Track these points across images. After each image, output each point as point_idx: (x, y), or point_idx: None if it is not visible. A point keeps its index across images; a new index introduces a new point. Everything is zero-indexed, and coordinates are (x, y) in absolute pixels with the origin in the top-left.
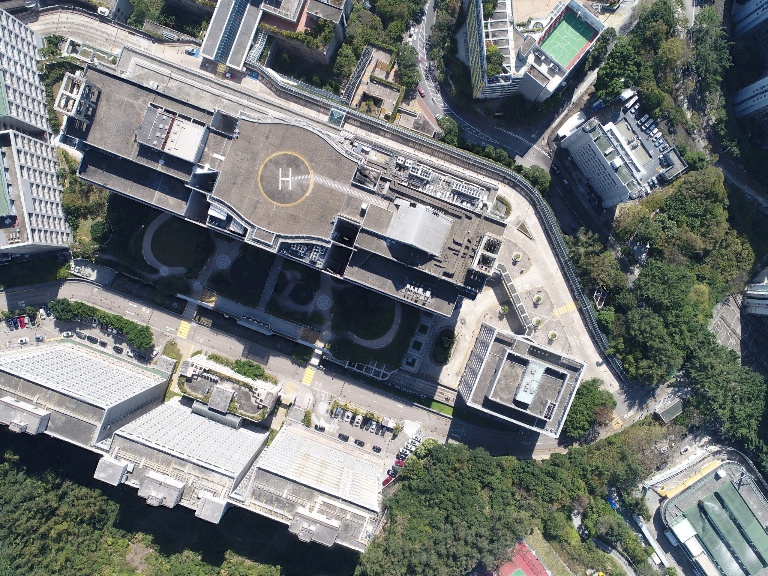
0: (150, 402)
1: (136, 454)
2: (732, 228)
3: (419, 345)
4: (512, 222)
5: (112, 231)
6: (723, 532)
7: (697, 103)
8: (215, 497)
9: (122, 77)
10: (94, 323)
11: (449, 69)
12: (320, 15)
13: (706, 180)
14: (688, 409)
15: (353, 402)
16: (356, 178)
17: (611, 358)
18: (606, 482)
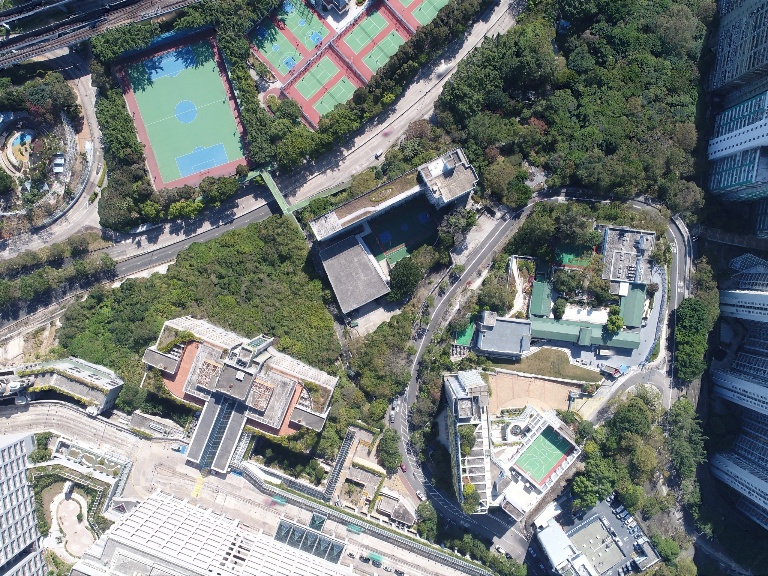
0: None
1: None
2: None
3: None
4: None
5: None
6: None
7: (673, 478)
8: None
9: None
10: None
11: (430, 445)
12: (303, 423)
13: None
14: None
15: None
16: None
17: None
18: None
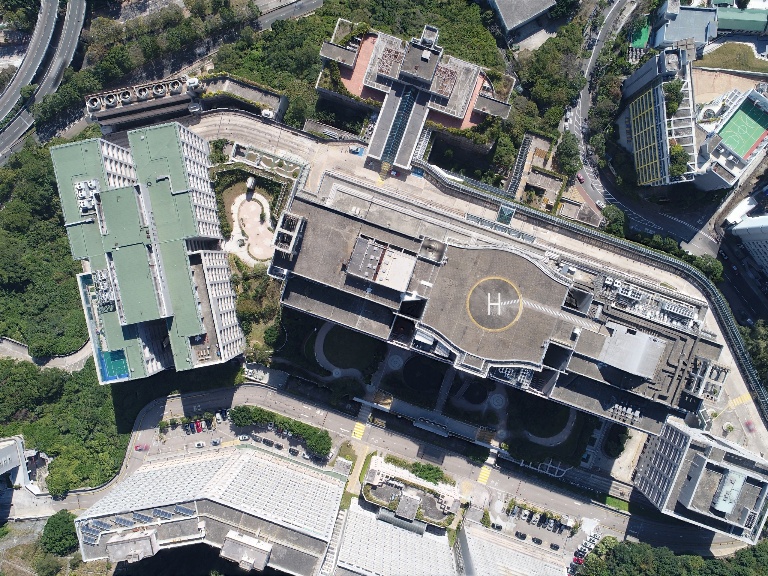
0: None
1: None
2: None
3: (593, 441)
4: None
5: (287, 336)
6: None
7: None
8: None
9: (329, 207)
10: (270, 426)
11: (608, 153)
12: (488, 111)
13: None
14: None
15: (530, 500)
16: (567, 302)
17: None
18: None
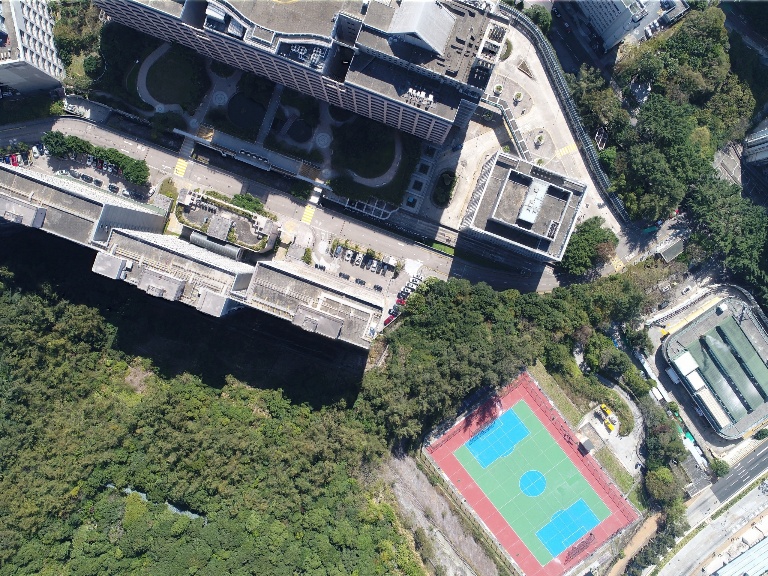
0: None
1: (135, 251)
2: (733, 73)
3: (420, 185)
4: (513, 61)
5: (106, 65)
6: (724, 366)
7: None
8: (216, 293)
9: None
10: (88, 161)
11: None
12: None
13: (708, 16)
14: (690, 246)
15: (353, 241)
16: None
17: (613, 198)
18: (608, 313)
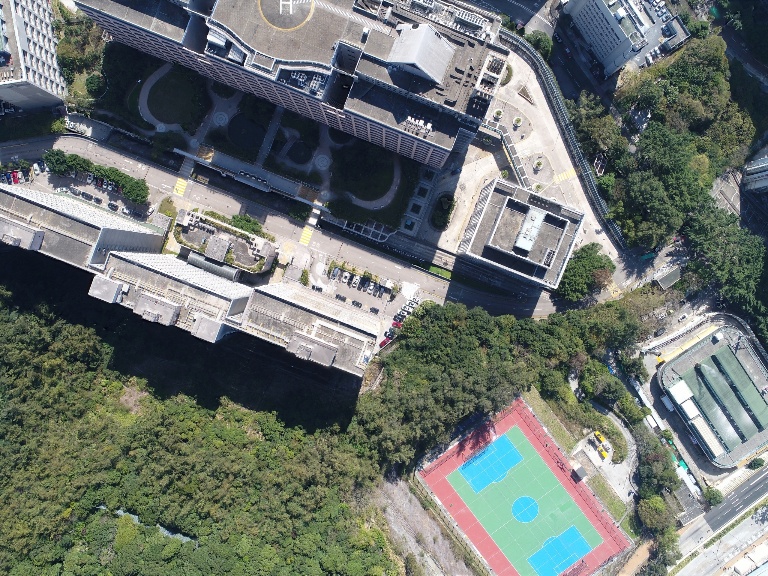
0: (145, 251)
1: (131, 275)
2: (733, 101)
3: (418, 208)
4: (513, 86)
5: (108, 84)
6: (719, 395)
7: None
8: (212, 318)
9: None
10: (89, 179)
11: None
12: None
13: (709, 45)
14: (687, 274)
15: (351, 263)
16: (358, 3)
17: (610, 224)
18: (604, 340)
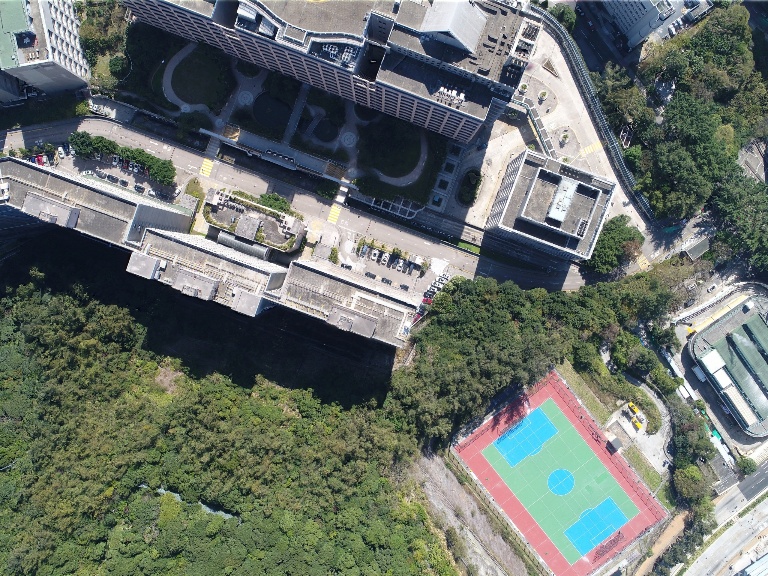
0: None
1: (168, 251)
2: (757, 70)
3: (445, 184)
4: (538, 60)
5: (132, 65)
6: (751, 363)
7: None
8: (250, 292)
9: None
10: (114, 161)
11: None
12: None
13: (733, 14)
14: (716, 244)
15: (380, 240)
16: None
17: (638, 196)
18: (636, 311)
